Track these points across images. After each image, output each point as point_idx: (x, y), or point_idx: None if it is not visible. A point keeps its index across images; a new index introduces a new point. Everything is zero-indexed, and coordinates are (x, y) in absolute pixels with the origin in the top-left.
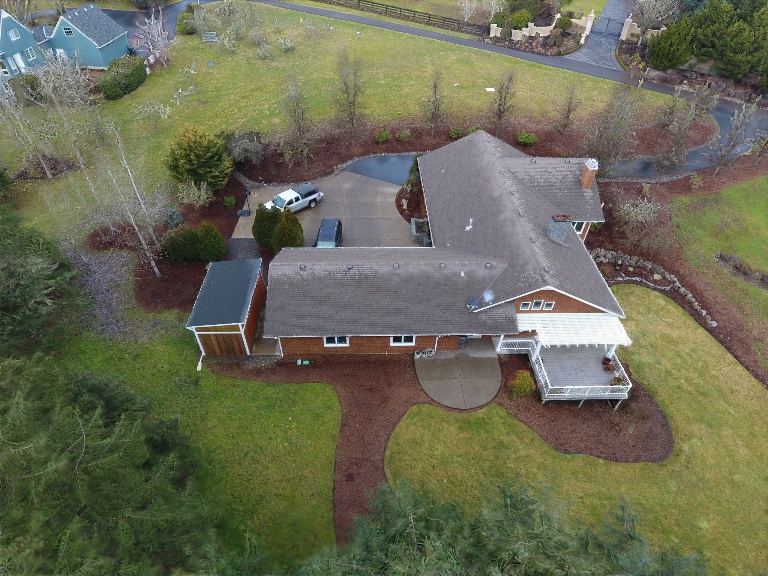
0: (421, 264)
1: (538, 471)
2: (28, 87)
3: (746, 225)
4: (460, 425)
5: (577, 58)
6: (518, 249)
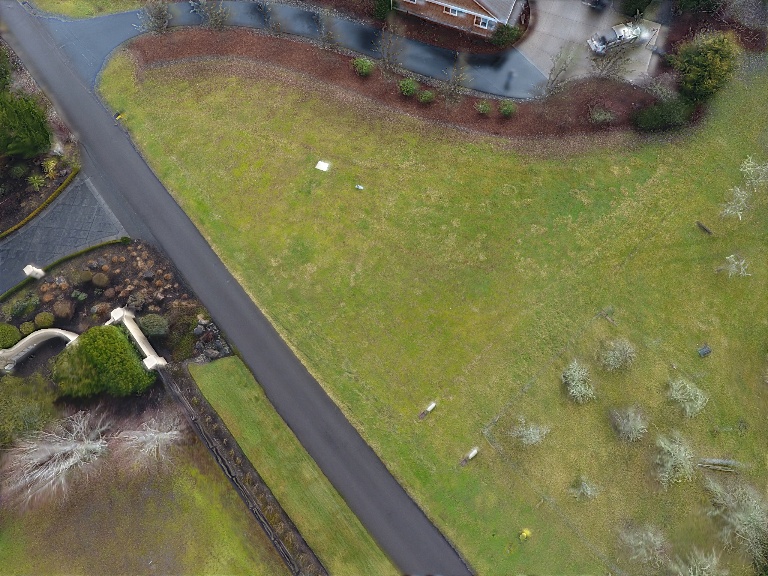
0: None
1: None
2: None
3: None
4: None
5: (107, 225)
6: None
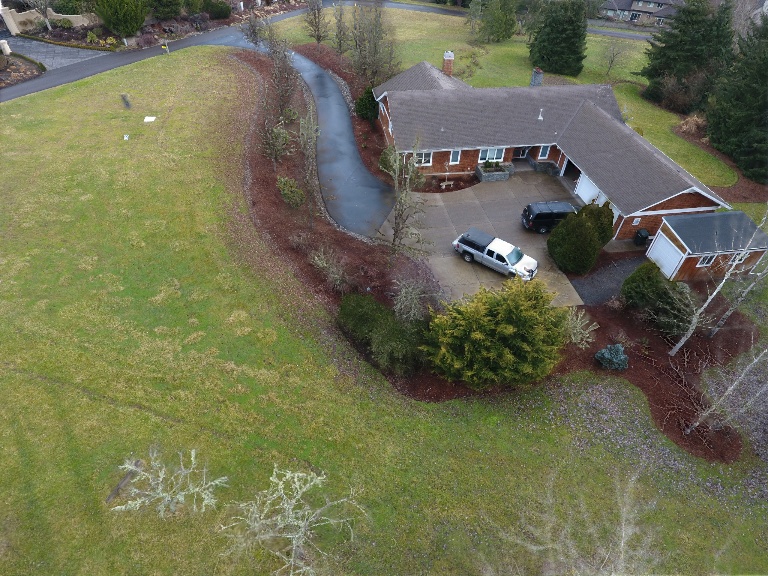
0: None
1: None
2: None
3: (401, 69)
4: None
5: (60, 63)
6: (575, 92)
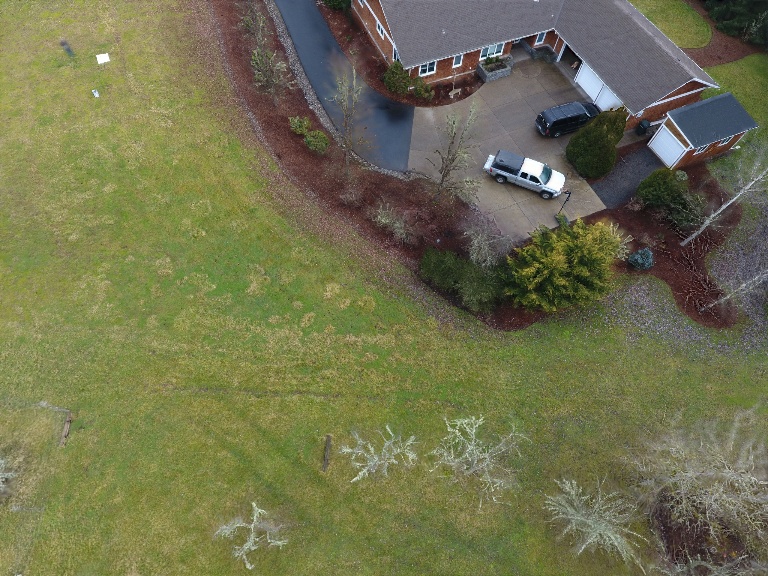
0: (617, 3)
1: (646, 1)
2: (764, 536)
3: None
4: (655, 23)
5: None
6: None
